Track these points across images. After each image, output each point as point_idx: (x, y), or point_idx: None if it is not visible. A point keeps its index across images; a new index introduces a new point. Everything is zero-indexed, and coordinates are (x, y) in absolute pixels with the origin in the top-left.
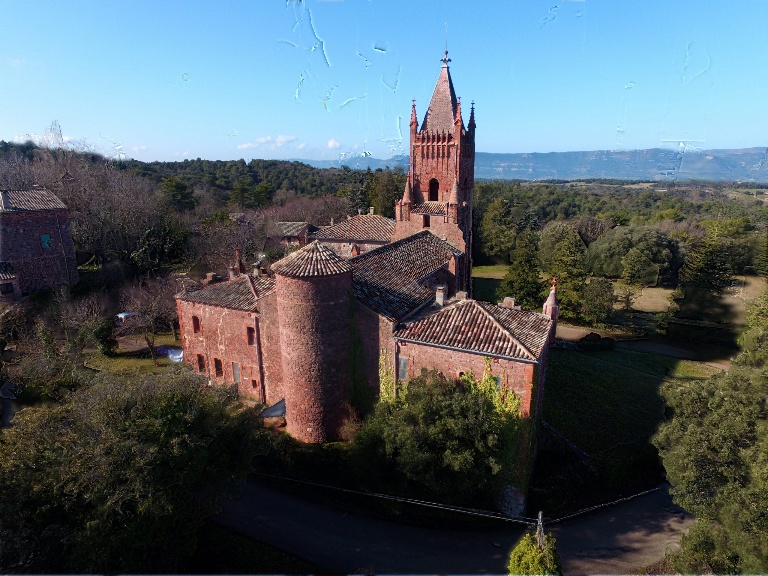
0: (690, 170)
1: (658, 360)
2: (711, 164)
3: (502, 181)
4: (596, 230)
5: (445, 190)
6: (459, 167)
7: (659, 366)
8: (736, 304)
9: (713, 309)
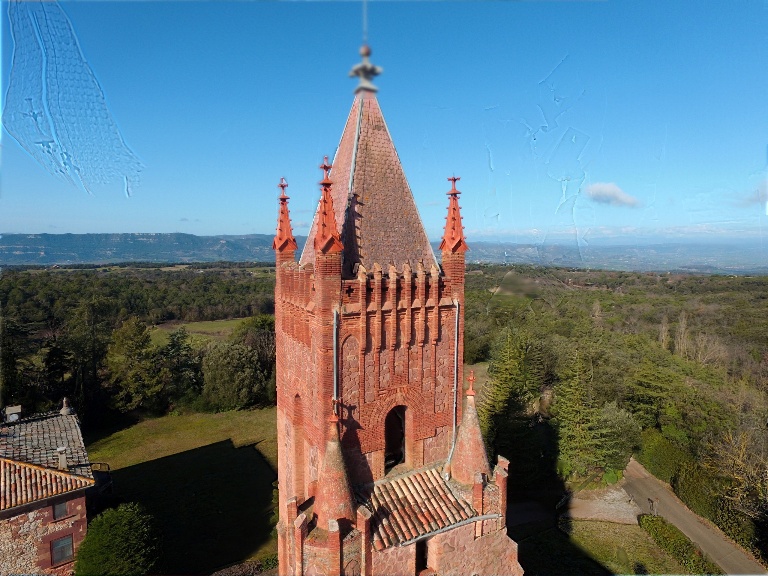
0: (503, 292)
1: (561, 547)
2: (528, 286)
3: (127, 294)
4: (271, 345)
5: (432, 432)
6: (460, 362)
7: (586, 562)
8: (546, 430)
9: (533, 443)
